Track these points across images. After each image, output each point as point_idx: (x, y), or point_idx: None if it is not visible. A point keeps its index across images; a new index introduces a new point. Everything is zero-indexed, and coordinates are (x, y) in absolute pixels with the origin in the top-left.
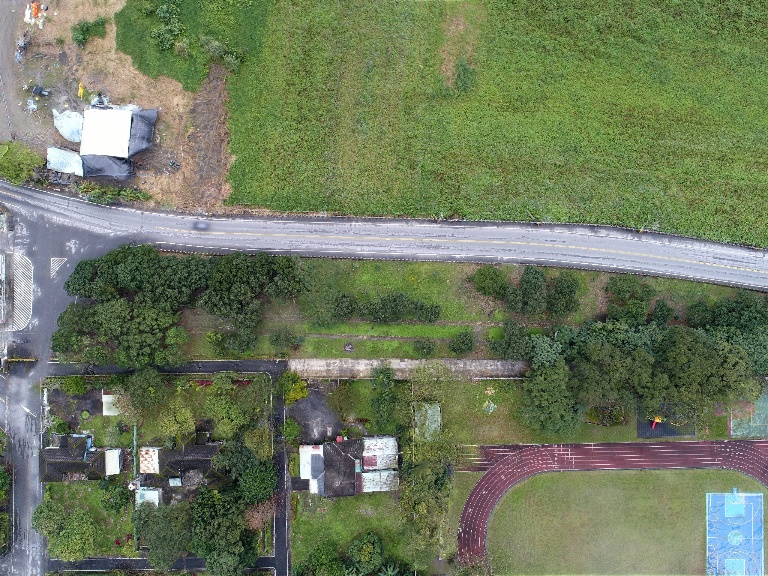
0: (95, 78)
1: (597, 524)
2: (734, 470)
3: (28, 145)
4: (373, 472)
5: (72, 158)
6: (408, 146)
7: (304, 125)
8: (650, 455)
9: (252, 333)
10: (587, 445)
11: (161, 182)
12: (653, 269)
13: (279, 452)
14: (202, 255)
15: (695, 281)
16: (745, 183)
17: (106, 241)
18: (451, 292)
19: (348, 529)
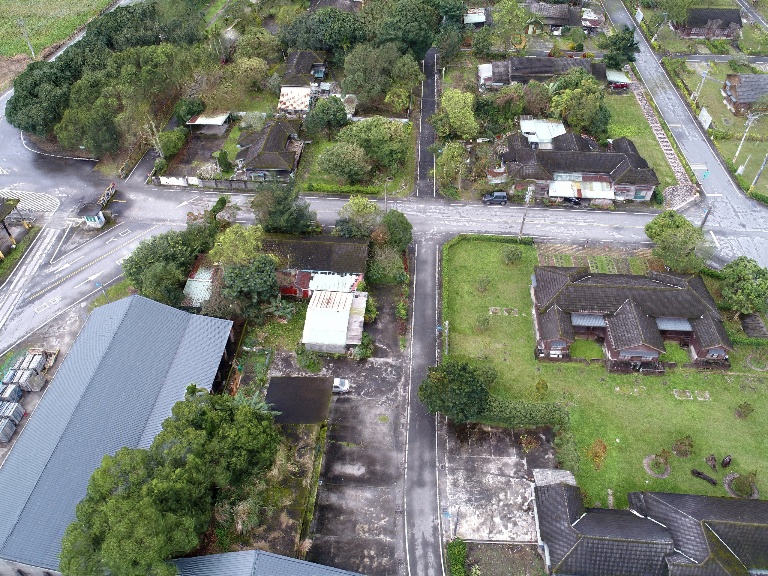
0: None
1: None
2: None
3: None
4: None
5: None
6: None
7: None
8: None
9: None
10: None
11: None
12: None
13: None
14: None
15: None
16: None
17: (1, 130)
18: None
19: None
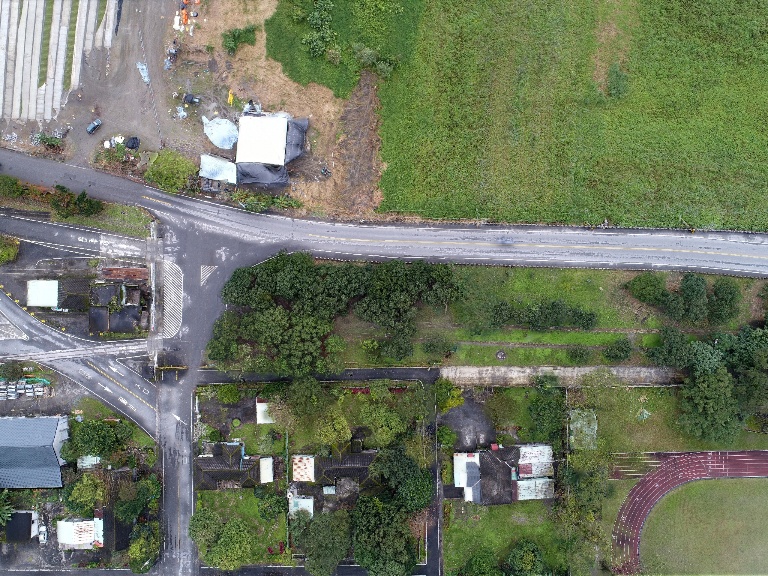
0: (245, 85)
1: (751, 532)
2: None
3: (179, 152)
4: (528, 480)
5: (224, 165)
6: (561, 153)
7: (456, 132)
8: None
9: (410, 341)
10: (741, 453)
11: (312, 189)
12: None
13: (431, 460)
14: (357, 263)
15: None
16: None
17: (256, 248)
18: (604, 299)
19: (500, 537)
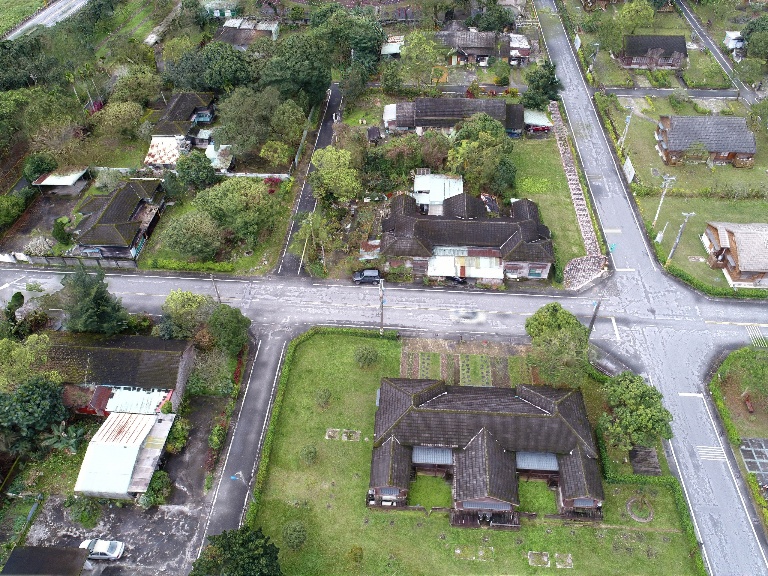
0: None
1: None
2: None
3: None
4: None
5: None
6: None
7: None
8: None
9: None
10: None
11: None
12: None
13: None
14: None
15: None
16: None
17: None
18: (115, 7)
19: None
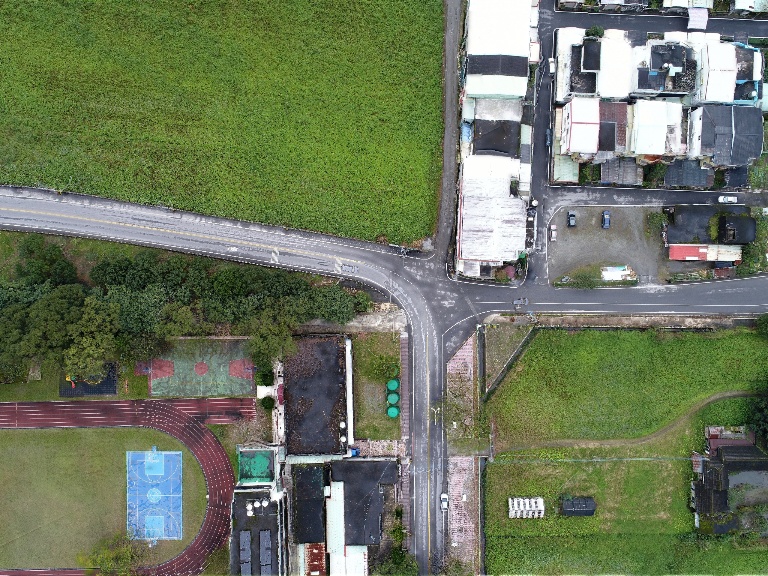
0: None
1: (20, 482)
2: (154, 428)
3: None
4: None
5: None
6: None
7: None
8: (72, 414)
9: None
10: (11, 404)
11: None
12: (74, 230)
13: None
14: None
15: (116, 242)
16: (164, 145)
17: None
18: None
19: None
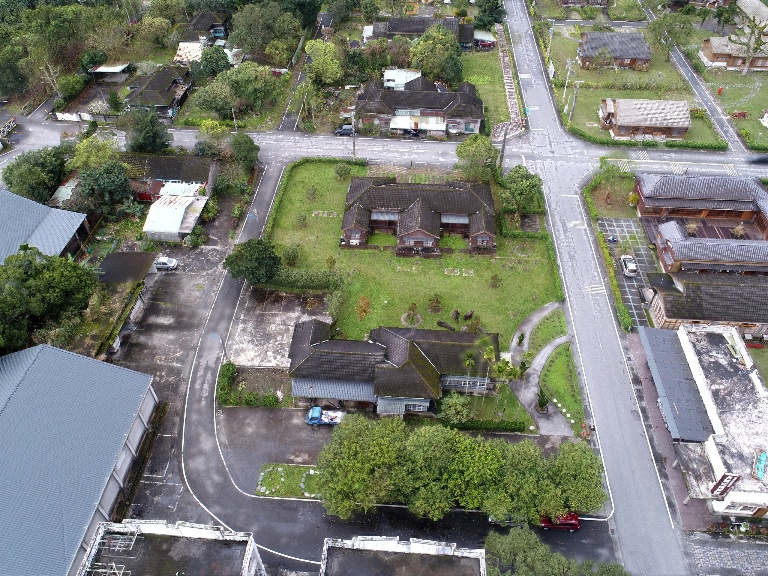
0: None
1: None
2: None
3: None
4: None
5: None
6: None
7: None
8: None
9: None
10: None
11: None
12: None
13: None
14: None
15: None
16: None
17: None
18: None
19: None
